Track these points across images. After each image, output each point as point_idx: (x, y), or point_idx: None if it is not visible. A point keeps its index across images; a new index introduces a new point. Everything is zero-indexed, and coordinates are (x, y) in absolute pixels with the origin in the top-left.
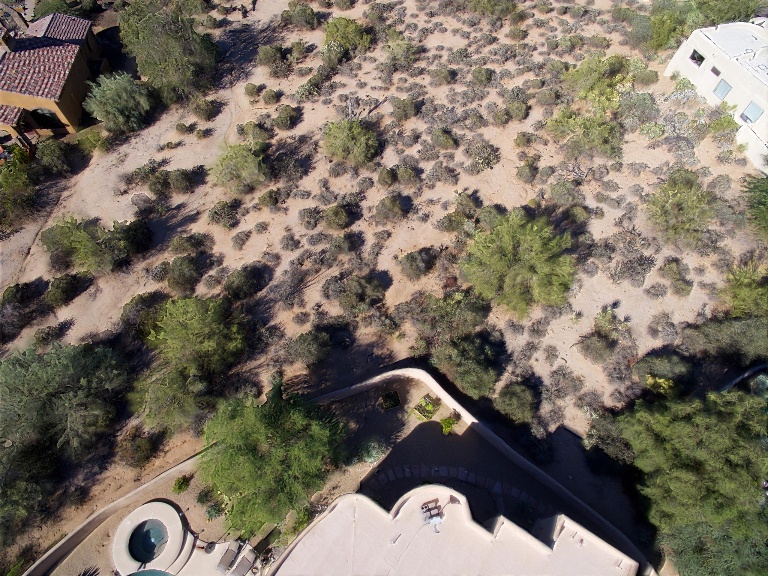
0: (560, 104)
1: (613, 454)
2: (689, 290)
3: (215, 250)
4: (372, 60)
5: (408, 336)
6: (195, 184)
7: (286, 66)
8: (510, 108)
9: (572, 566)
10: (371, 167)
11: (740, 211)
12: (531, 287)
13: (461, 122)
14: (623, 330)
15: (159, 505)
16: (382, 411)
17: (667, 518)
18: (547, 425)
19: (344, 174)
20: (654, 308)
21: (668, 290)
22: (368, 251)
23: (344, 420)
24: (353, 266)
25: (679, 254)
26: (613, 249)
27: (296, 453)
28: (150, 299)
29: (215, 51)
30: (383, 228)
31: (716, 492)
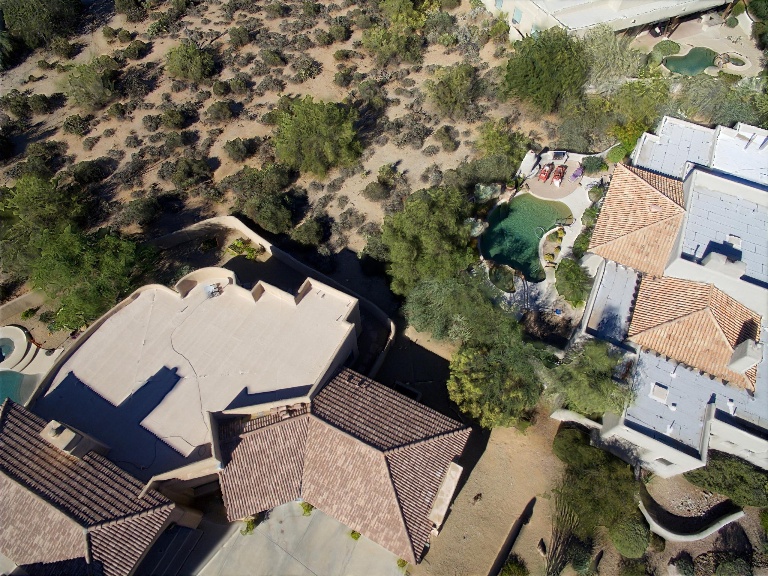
0: (377, 27)
1: (374, 255)
2: (453, 145)
3: (68, 153)
4: (217, 2)
5: (230, 200)
6: (54, 107)
7: (141, 12)
8: (332, 31)
9: (313, 310)
10: (208, 82)
11: (504, 90)
12: (326, 152)
13: (291, 45)
14: (399, 178)
15: (8, 328)
16: (202, 252)
17: (396, 281)
18: (334, 249)
19: (185, 89)
20: (428, 162)
21: (440, 149)
22: (202, 144)
23: (170, 261)
24: (188, 155)
25: (453, 124)
26: (401, 125)
27: (106, 260)
28: (7, 190)
29: (78, 4)
30: (216, 127)
31: (425, 254)
